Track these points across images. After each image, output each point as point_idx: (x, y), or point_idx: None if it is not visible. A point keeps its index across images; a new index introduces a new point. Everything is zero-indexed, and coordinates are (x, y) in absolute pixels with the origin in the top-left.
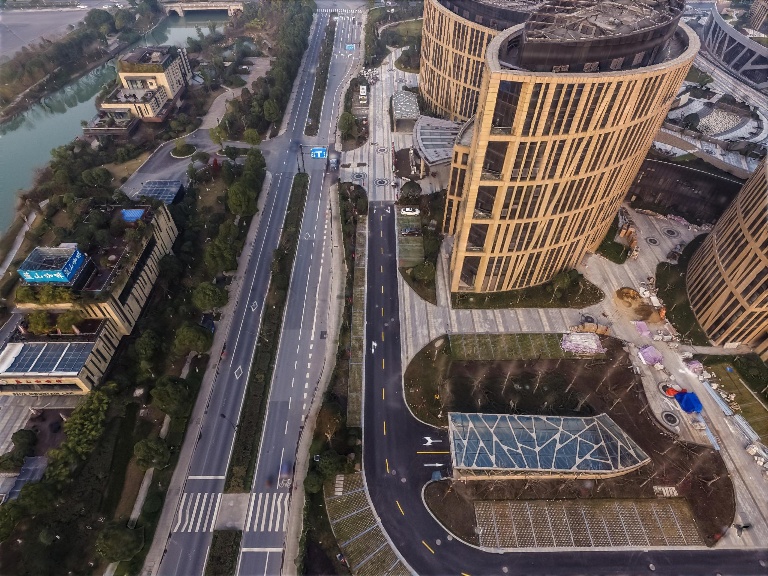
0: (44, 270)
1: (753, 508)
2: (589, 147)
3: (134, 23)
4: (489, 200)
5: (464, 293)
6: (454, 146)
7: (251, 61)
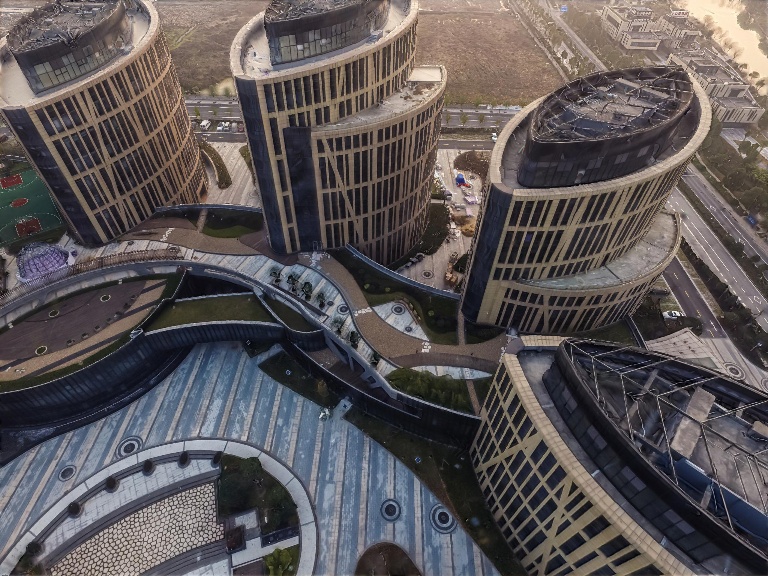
0: None
1: (450, 156)
2: None
3: None
4: None
5: None
6: None
7: None
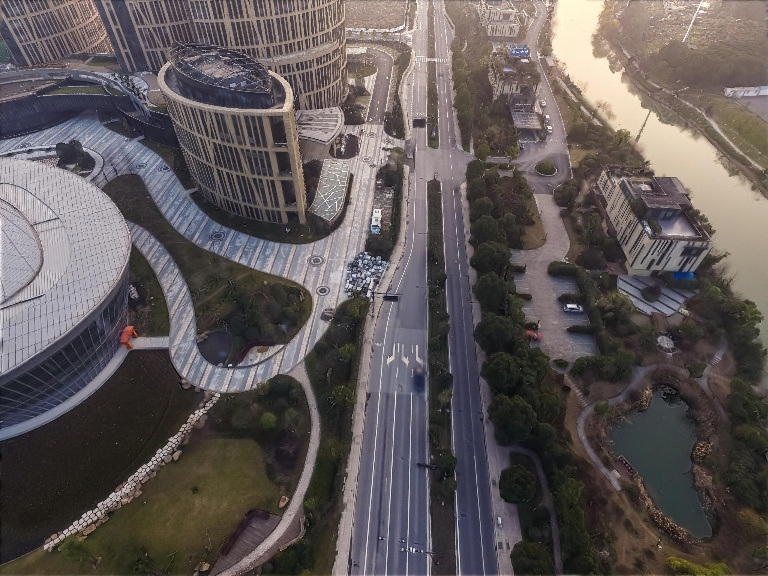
0: None
1: None
2: None
3: None
4: None
5: None
6: None
7: None
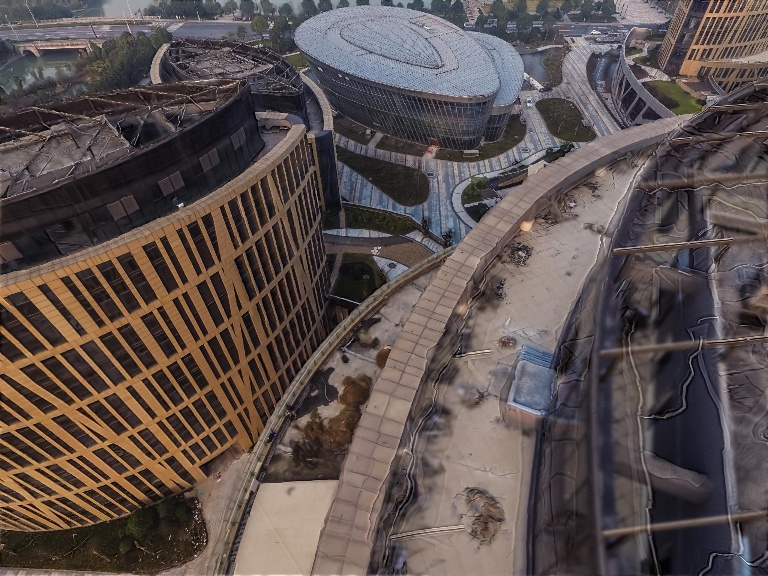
0: None
1: None
2: None
3: None
4: None
5: (1, 531)
6: None
7: None
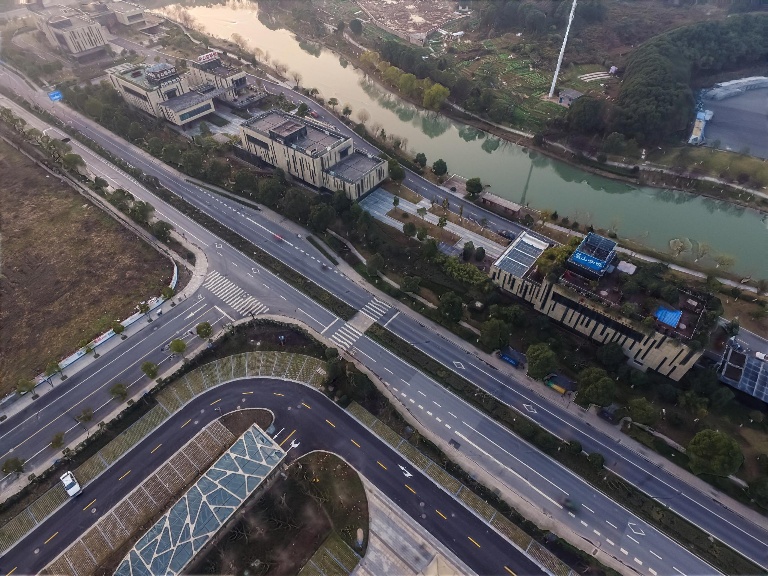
0: None
1: None
2: None
3: None
4: None
5: None
6: None
7: None
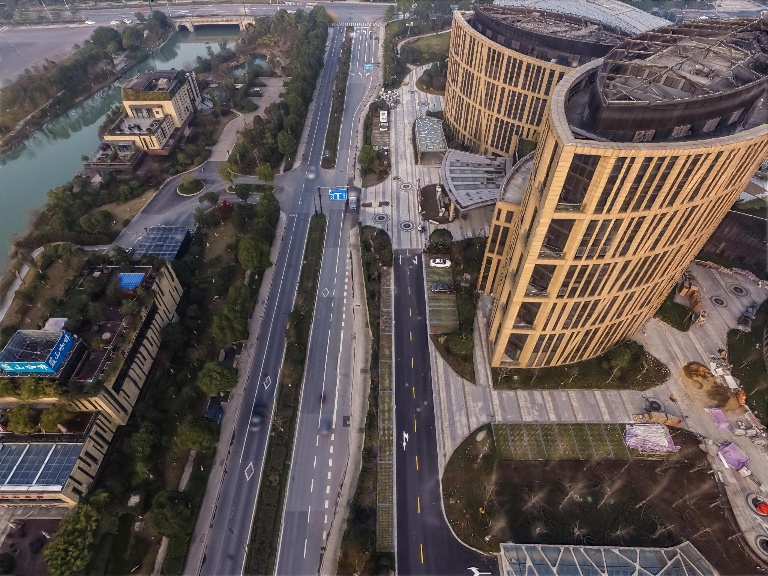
0: (26, 360)
1: None
2: (672, 222)
3: (142, 40)
4: (544, 276)
5: (506, 369)
6: (497, 203)
7: (263, 82)
